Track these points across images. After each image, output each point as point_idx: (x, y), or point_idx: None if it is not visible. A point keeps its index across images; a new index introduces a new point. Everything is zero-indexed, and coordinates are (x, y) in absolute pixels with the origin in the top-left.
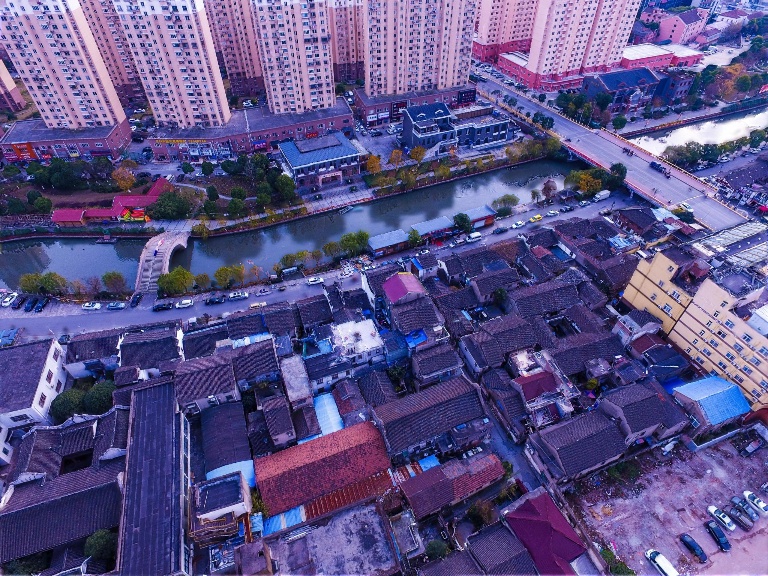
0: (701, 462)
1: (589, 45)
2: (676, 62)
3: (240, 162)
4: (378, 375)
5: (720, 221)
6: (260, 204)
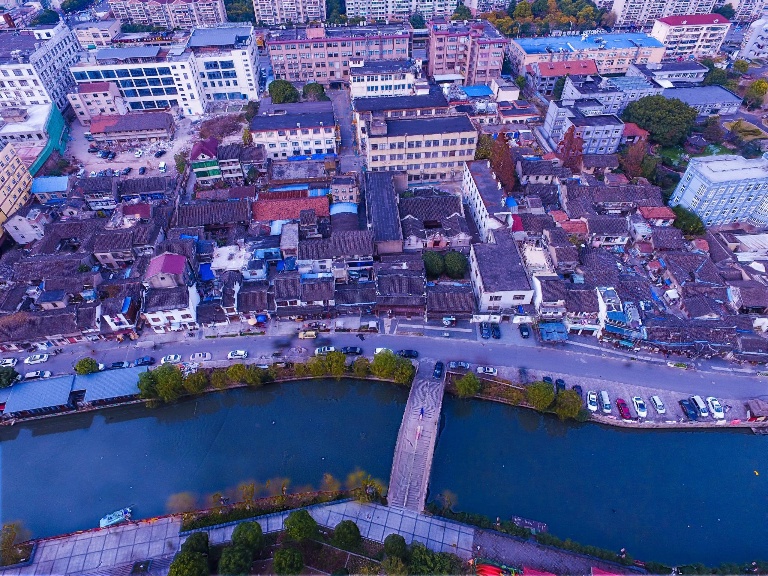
0: None
1: None
2: None
3: None
4: (232, 242)
5: None
6: None
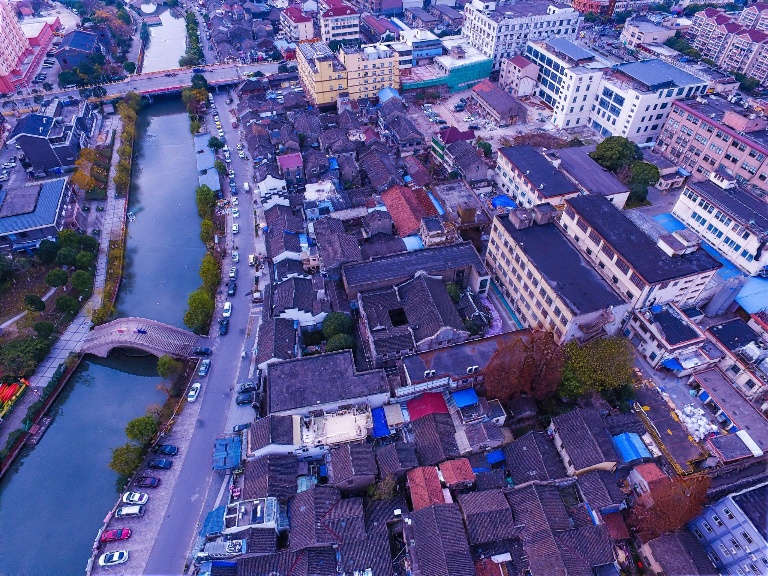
0: (410, 118)
1: (6, 35)
2: (53, 29)
3: None
4: None
5: None
6: (89, 263)
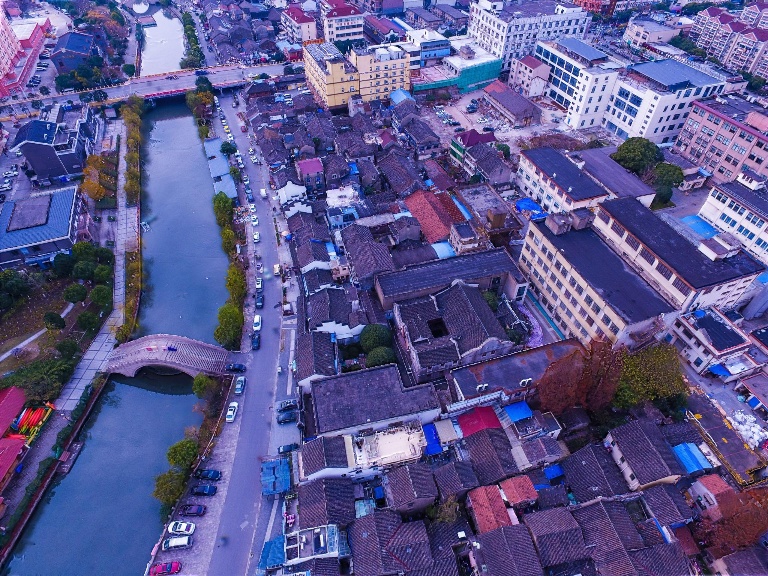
0: (423, 120)
1: None
2: (44, 31)
3: None
4: None
5: (270, 71)
6: None
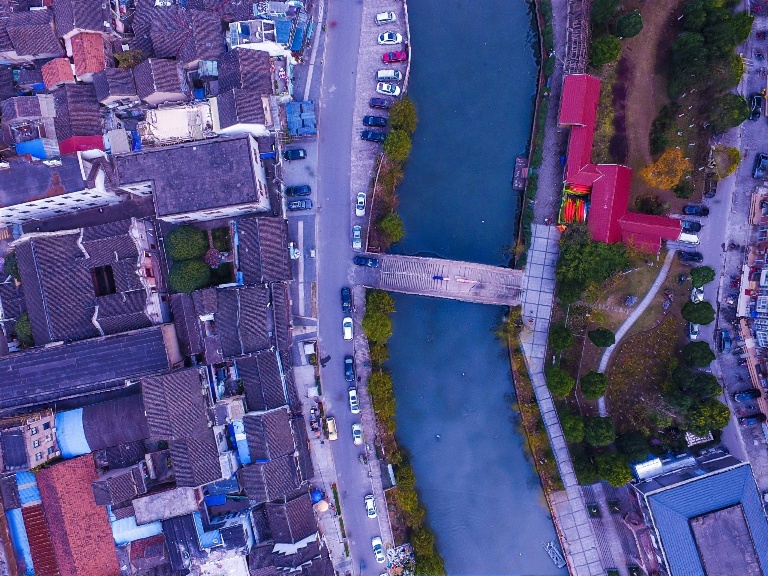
0: None
1: None
2: None
3: (699, 383)
4: None
5: None
6: None
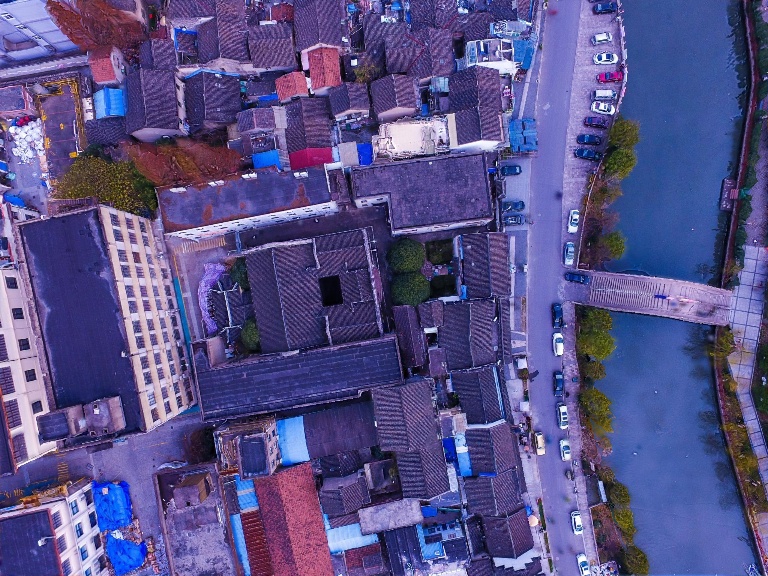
0: None
1: None
2: None
3: None
4: None
5: None
6: None
